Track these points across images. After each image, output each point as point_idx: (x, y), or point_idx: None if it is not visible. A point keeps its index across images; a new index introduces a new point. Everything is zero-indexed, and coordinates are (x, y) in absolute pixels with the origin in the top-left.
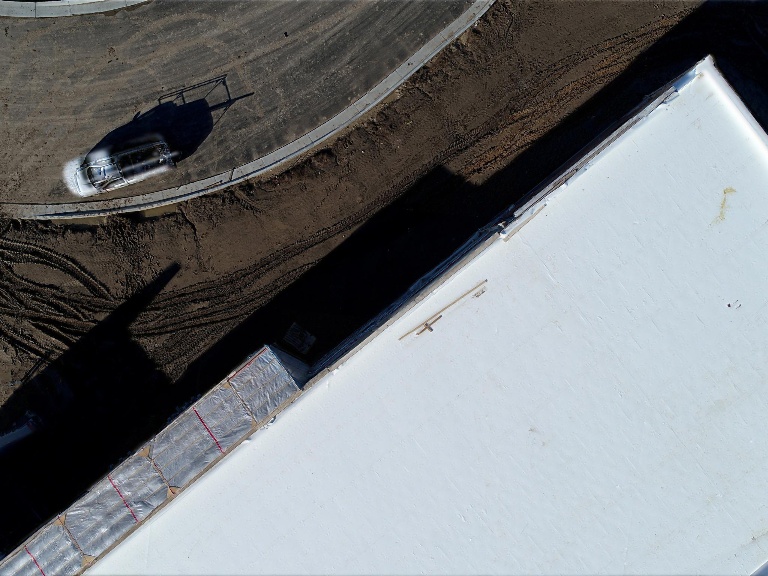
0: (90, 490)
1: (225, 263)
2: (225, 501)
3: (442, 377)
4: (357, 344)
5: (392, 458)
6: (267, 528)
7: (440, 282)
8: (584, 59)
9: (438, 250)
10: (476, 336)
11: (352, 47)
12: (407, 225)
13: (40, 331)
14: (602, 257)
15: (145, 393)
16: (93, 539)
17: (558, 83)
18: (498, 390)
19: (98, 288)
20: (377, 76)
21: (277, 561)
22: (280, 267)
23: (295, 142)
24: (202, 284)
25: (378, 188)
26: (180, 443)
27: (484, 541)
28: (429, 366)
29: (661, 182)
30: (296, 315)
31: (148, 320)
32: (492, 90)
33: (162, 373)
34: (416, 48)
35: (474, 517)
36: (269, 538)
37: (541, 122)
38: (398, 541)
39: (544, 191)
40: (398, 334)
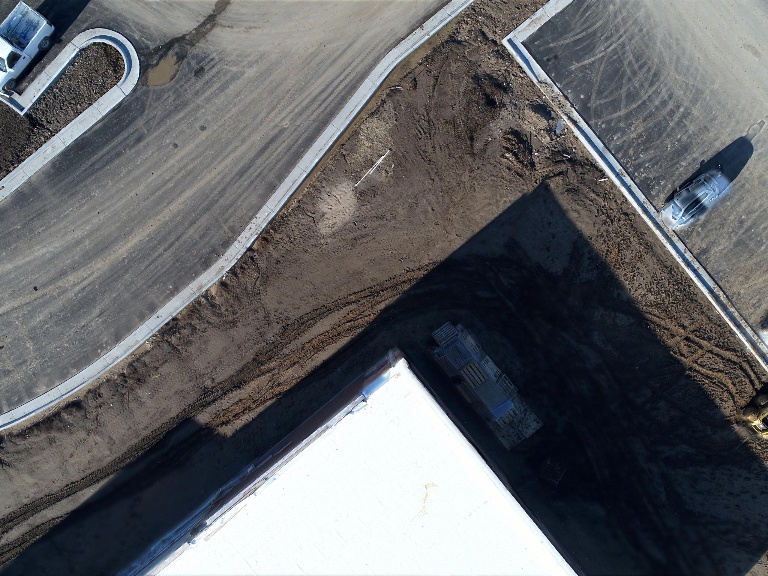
0: None
1: None
2: None
3: None
4: None
5: None
6: None
7: None
8: (330, 312)
9: (187, 502)
10: None
11: (102, 300)
12: (156, 478)
13: None
14: (305, 553)
15: None
16: None
17: (305, 336)
18: None
19: None
20: (127, 328)
21: None
22: (29, 521)
23: (45, 395)
24: None
25: (127, 441)
26: None
27: None
28: None
29: (362, 479)
30: (45, 568)
31: None
32: (239, 343)
33: None
34: (165, 300)
35: None
36: None
37: (289, 374)
38: None
39: (235, 499)
40: None
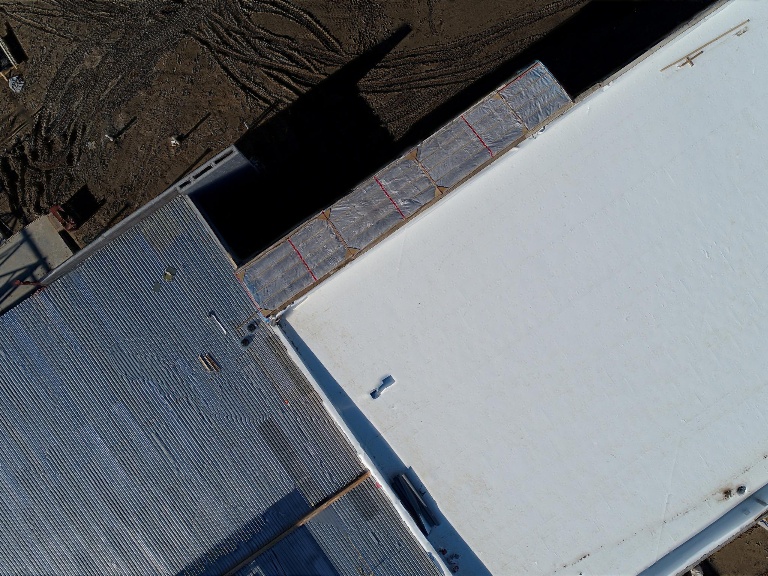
0: (355, 189)
1: (456, 28)
2: (479, 216)
3: (698, 112)
4: (629, 62)
5: (643, 188)
6: (517, 247)
7: (714, 8)
8: None
9: (662, 32)
10: (734, 74)
11: None
12: (634, 5)
13: (272, 79)
14: None
15: (368, 148)
16: (358, 233)
17: None
18: (751, 130)
19: (331, 43)
20: None
21: (524, 281)
22: (509, 36)
23: None
24: (432, 47)
25: None
26: (449, 147)
27: (725, 279)
28: (687, 100)
29: None
30: None
31: (377, 78)
32: None
33: (386, 130)
34: None
35: (717, 254)
36: (518, 257)
37: None
38: (642, 271)
39: None
40: (660, 65)
